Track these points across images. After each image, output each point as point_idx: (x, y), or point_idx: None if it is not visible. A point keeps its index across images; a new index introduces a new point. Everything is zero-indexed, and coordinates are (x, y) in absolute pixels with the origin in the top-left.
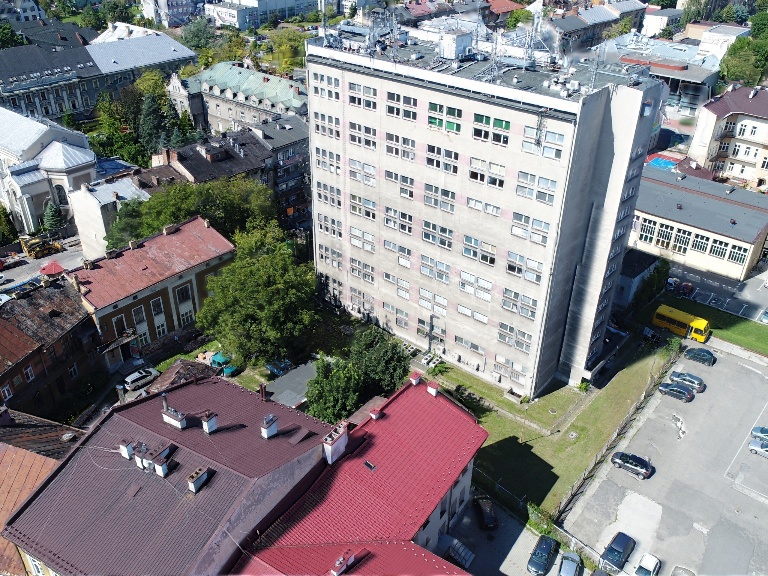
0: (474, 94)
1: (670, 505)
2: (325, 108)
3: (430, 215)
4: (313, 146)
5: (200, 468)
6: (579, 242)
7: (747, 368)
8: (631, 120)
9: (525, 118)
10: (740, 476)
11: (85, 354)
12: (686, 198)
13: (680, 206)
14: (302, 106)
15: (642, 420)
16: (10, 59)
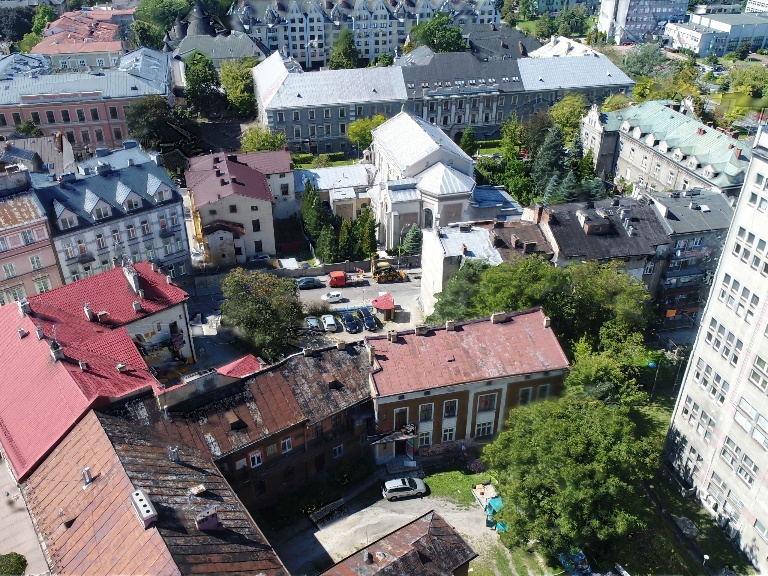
0: None
1: None
2: (758, 227)
3: None
4: (722, 270)
5: None
6: None
7: None
8: None
9: None
10: None
11: (354, 437)
12: None
13: None
14: (738, 175)
15: None
16: (442, 64)
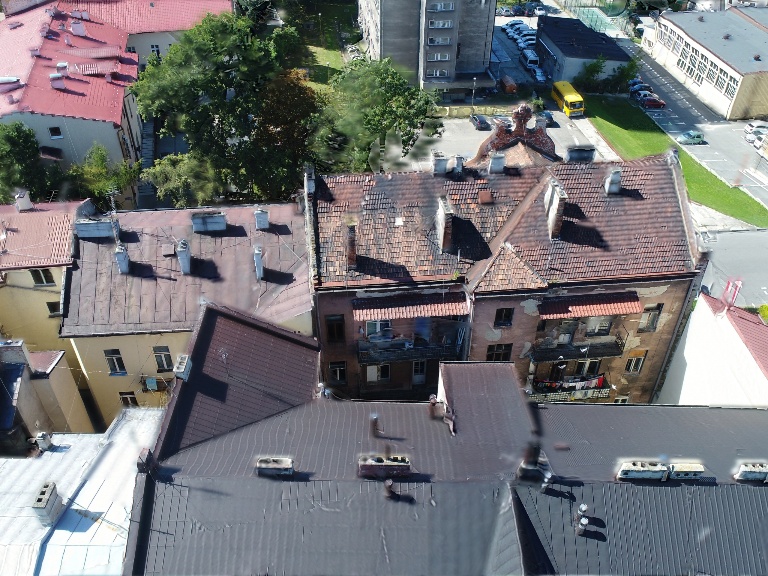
0: None
1: None
2: None
3: None
4: None
5: None
6: None
7: (573, 139)
8: None
9: None
10: (428, 162)
11: None
12: (752, 35)
13: (727, 36)
14: None
15: None
16: None
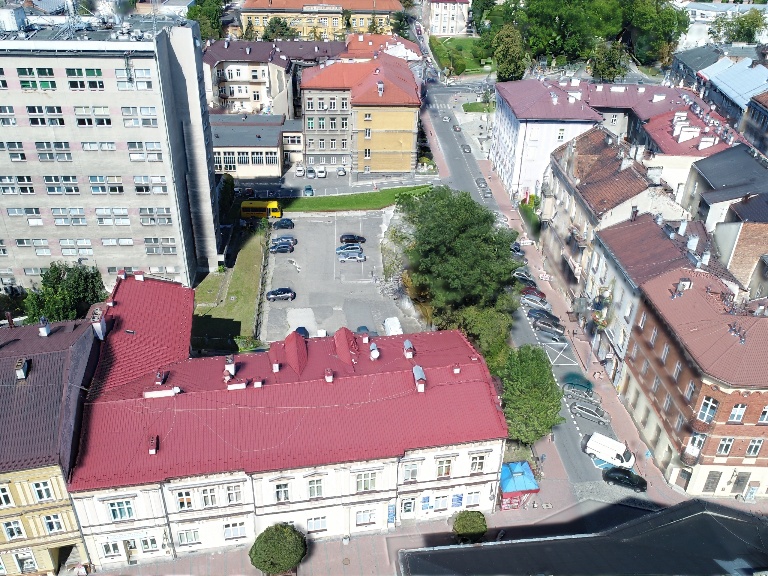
0: (60, 52)
1: (315, 306)
2: None
3: (49, 169)
4: None
5: (20, 359)
6: (181, 155)
7: (314, 222)
8: (190, 51)
9: (113, 63)
10: (343, 276)
11: None
12: (218, 130)
13: (217, 136)
14: None
15: (272, 271)
16: None
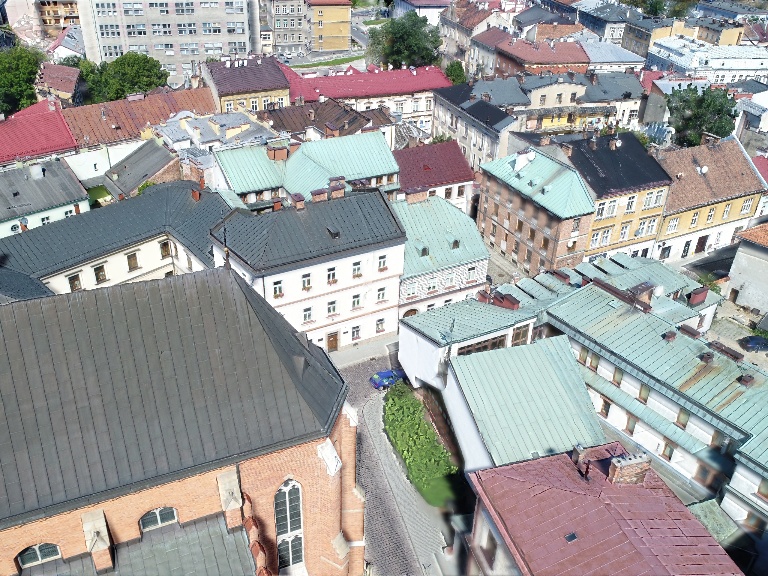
0: None
1: None
2: None
3: (181, 19)
4: (94, 3)
5: None
6: None
7: None
8: None
9: None
10: None
11: None
12: None
13: None
14: None
15: None
16: None
